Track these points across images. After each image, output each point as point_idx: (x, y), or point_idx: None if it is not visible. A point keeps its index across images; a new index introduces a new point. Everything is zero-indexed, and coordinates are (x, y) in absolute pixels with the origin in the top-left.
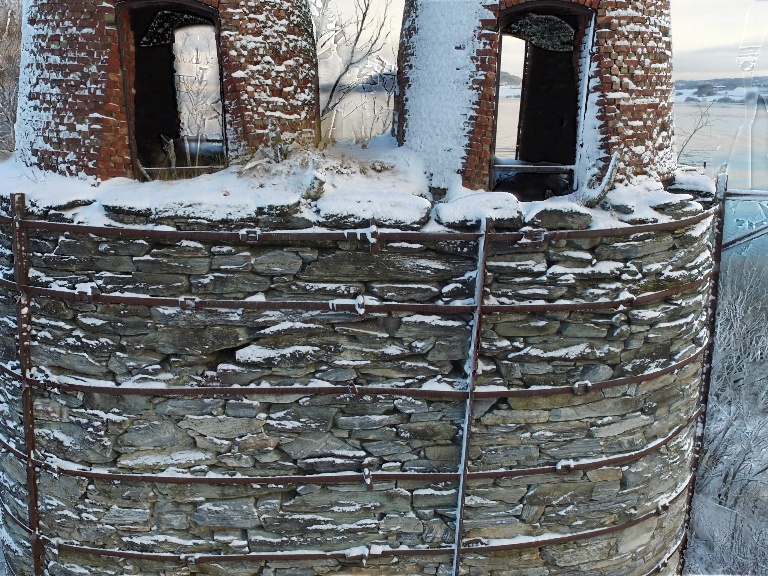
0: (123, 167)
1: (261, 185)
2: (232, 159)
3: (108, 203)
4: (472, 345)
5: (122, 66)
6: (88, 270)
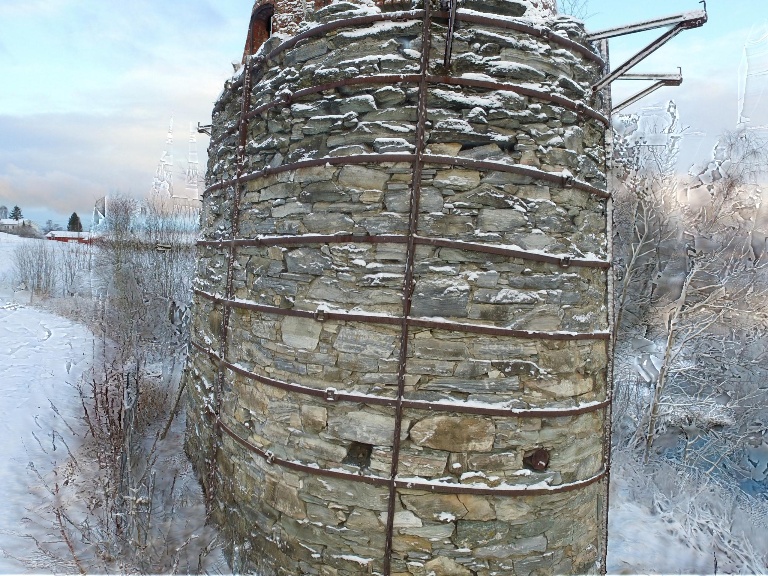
0: None
1: None
2: None
3: None
4: None
5: (251, 46)
6: None
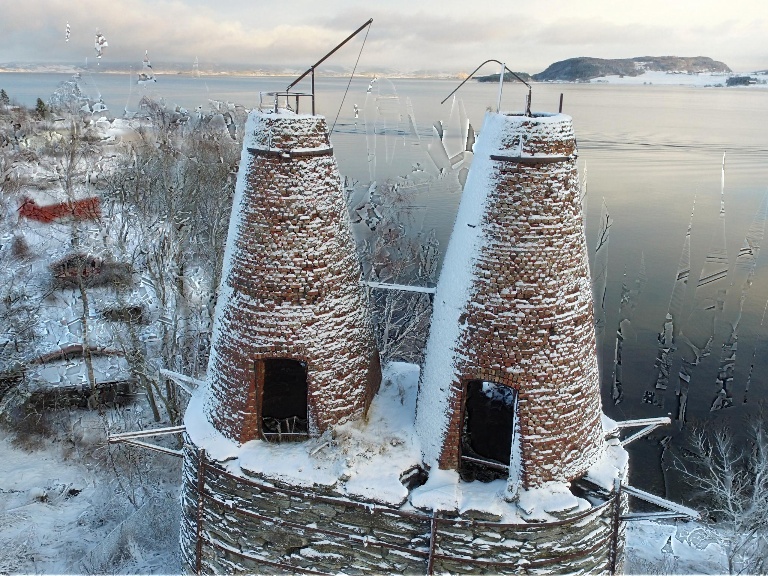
0: (254, 435)
1: (319, 467)
2: (311, 433)
3: (243, 466)
4: (427, 574)
5: (256, 387)
6: (232, 494)
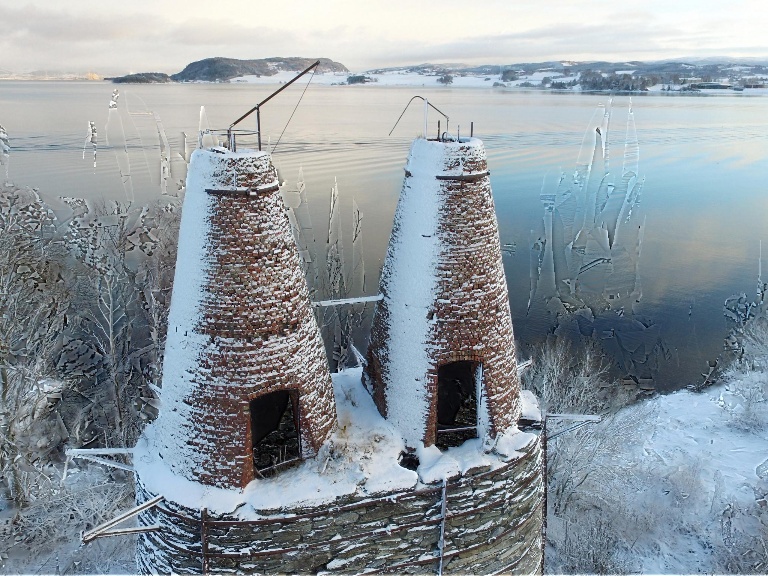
0: (251, 476)
1: (335, 481)
2: (305, 455)
3: (259, 508)
4: (442, 536)
5: None
6: (247, 541)
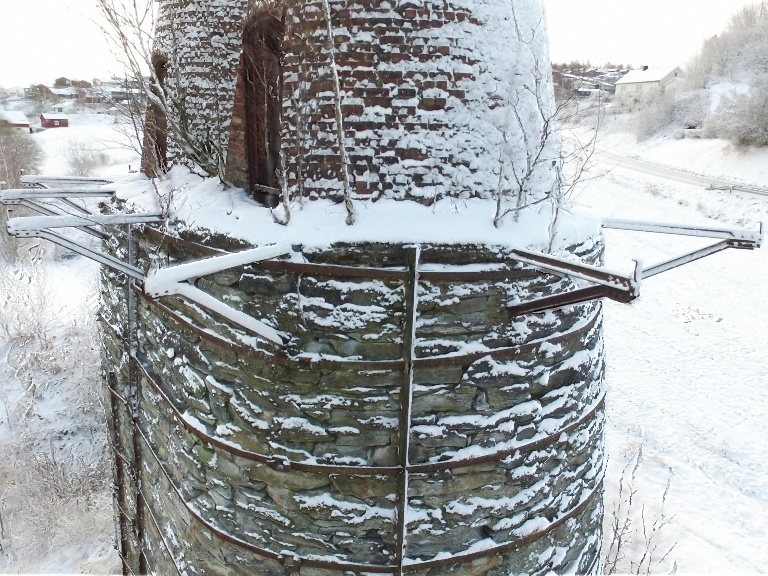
0: None
1: None
2: None
3: None
4: None
5: None
6: None
